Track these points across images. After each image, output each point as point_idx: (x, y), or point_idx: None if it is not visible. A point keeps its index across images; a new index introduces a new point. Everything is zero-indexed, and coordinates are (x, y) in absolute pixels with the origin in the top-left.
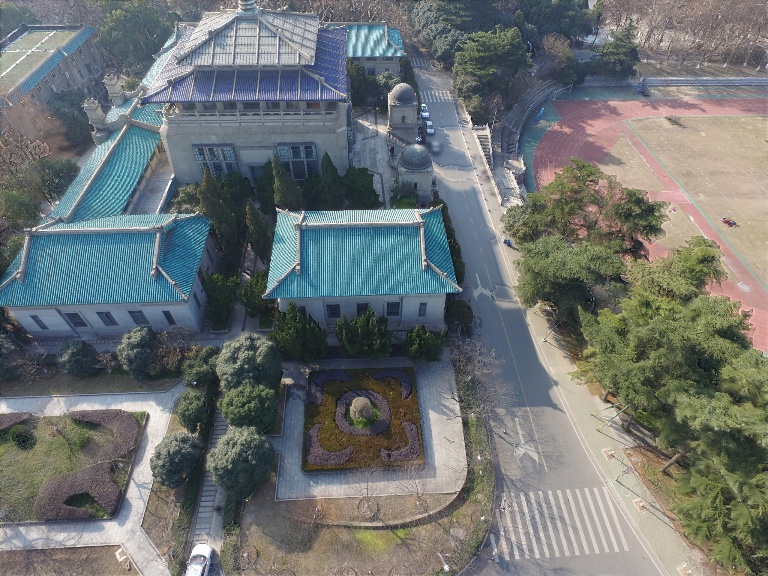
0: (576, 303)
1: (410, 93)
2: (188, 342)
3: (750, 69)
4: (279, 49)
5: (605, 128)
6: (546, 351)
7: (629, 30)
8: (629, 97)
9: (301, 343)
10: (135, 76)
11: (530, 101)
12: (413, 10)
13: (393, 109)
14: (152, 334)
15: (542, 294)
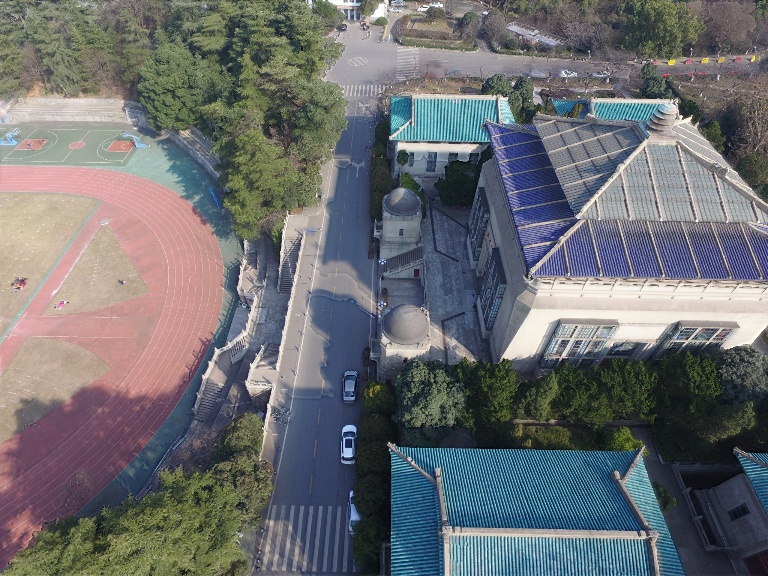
0: None
1: None
2: None
3: None
4: None
5: None
6: None
7: None
8: None
9: None
10: None
11: None
12: None
13: None
14: None
15: None
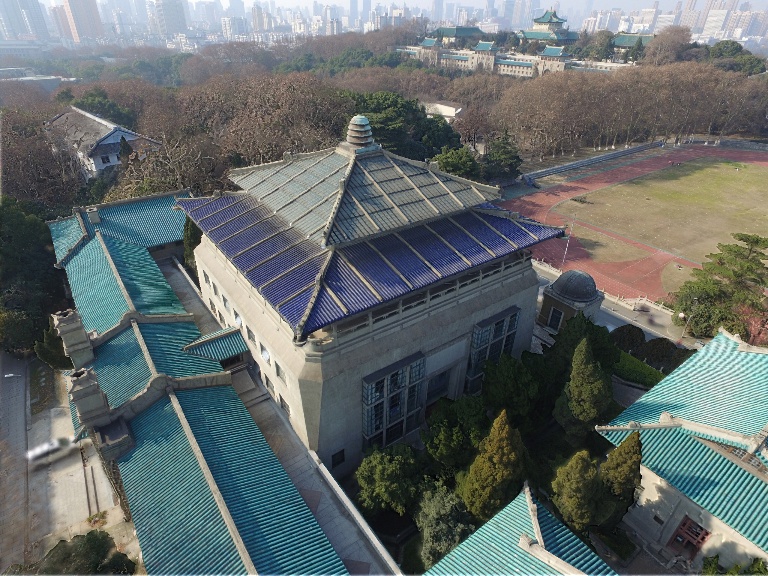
0: None
1: None
2: None
3: (569, 156)
4: (446, 187)
5: (547, 219)
6: None
7: (507, 139)
8: (529, 191)
9: None
10: (4, 308)
11: None
12: None
13: None
14: None
15: None
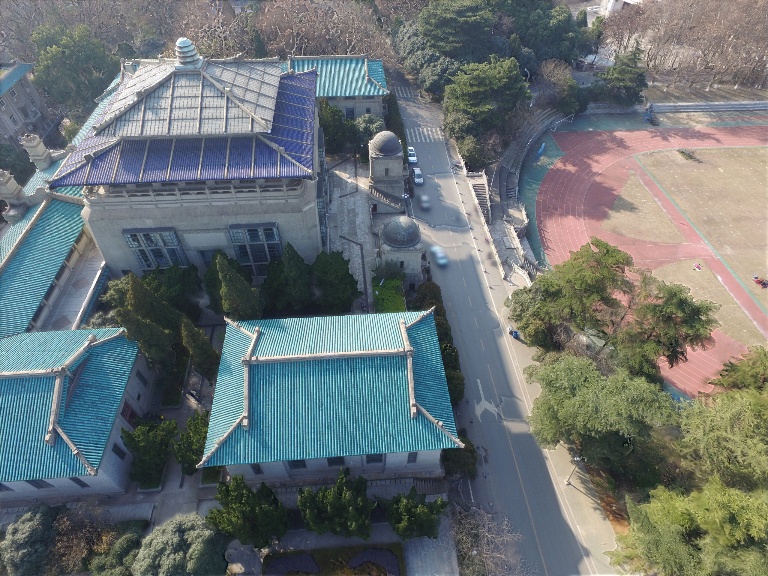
0: (611, 452)
1: (394, 143)
2: (98, 529)
3: (763, 91)
4: (227, 113)
5: (613, 165)
6: (570, 500)
7: (635, 54)
8: (636, 126)
9: (251, 525)
10: (77, 121)
11: (529, 134)
12: (397, 34)
13: (375, 161)
14: (49, 520)
15: (566, 438)
